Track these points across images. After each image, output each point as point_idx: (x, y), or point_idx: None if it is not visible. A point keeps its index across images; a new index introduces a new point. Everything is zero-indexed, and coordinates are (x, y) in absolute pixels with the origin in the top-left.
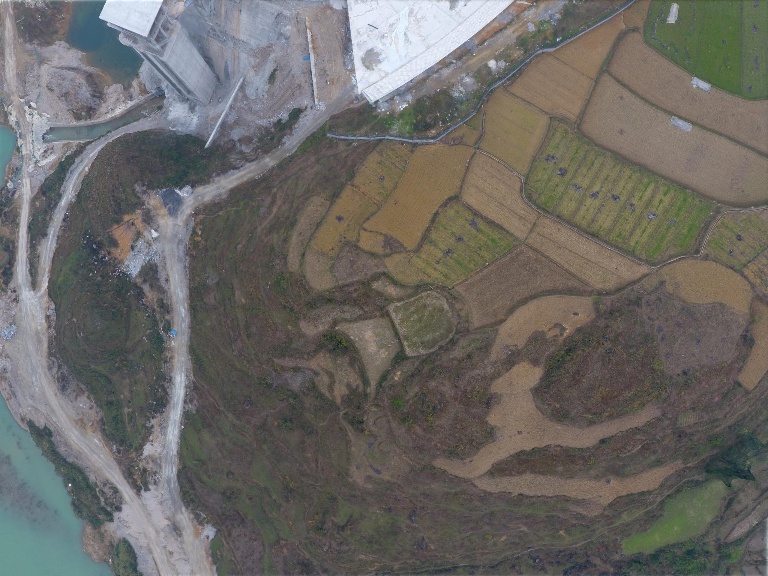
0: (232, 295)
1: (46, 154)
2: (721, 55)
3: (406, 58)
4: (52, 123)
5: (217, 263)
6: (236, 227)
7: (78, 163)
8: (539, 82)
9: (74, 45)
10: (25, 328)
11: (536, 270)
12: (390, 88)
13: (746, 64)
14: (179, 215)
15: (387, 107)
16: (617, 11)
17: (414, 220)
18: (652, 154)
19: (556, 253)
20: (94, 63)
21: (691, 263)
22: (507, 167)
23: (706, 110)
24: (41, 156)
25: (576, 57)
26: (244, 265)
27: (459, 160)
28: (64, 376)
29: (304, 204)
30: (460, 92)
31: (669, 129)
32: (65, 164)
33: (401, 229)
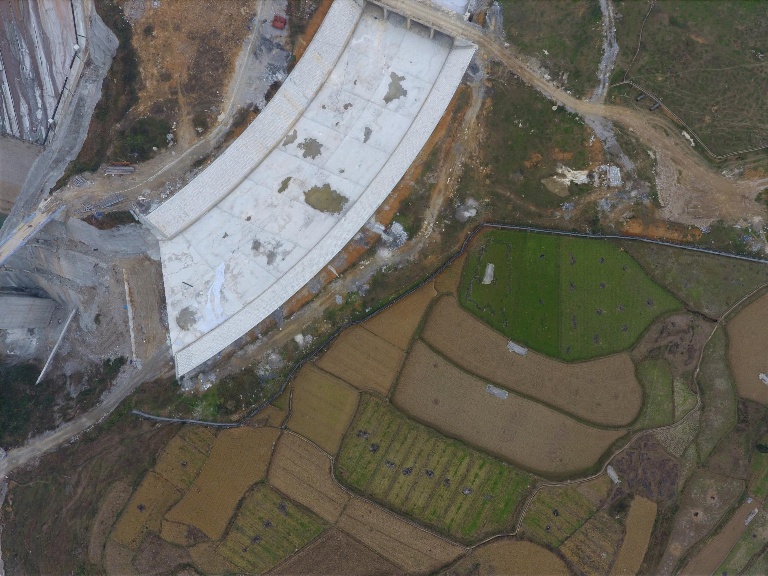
0: None
1: None
2: (538, 316)
3: (222, 317)
4: None
5: (25, 541)
6: (44, 504)
7: None
8: (348, 355)
9: None
10: None
11: (347, 555)
12: (198, 360)
13: (564, 324)
14: None
15: (191, 386)
16: (426, 282)
17: (218, 508)
18: (468, 424)
19: (368, 536)
20: None
21: (506, 544)
22: (316, 447)
23: (523, 375)
24: None
25: (386, 328)
26: (48, 549)
27: (265, 443)
28: None
29: (106, 490)
30: (266, 370)
31: (485, 397)
32: None
33: (204, 519)
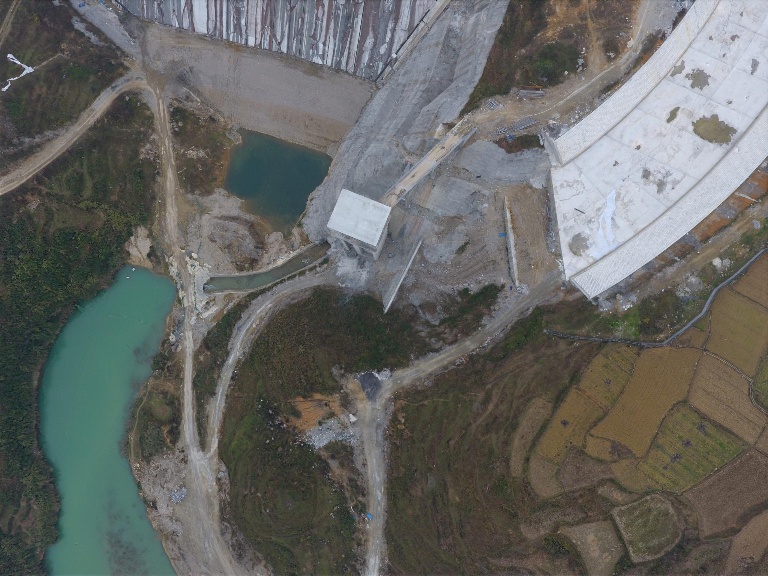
0: (444, 492)
1: (208, 306)
2: None
3: (614, 243)
4: (213, 274)
5: (426, 457)
6: (446, 420)
7: (245, 319)
8: (764, 280)
9: (232, 192)
10: (195, 491)
11: (766, 475)
12: (608, 283)
13: None
14: (378, 399)
15: (610, 307)
16: None
17: (642, 426)
18: None
19: None
20: (253, 210)
21: None
22: (735, 369)
23: None
24: (203, 308)
25: None
26: (459, 464)
27: (687, 363)
28: (240, 544)
29: (526, 406)
30: (686, 292)
31: None
32: (231, 320)
33: (629, 435)
